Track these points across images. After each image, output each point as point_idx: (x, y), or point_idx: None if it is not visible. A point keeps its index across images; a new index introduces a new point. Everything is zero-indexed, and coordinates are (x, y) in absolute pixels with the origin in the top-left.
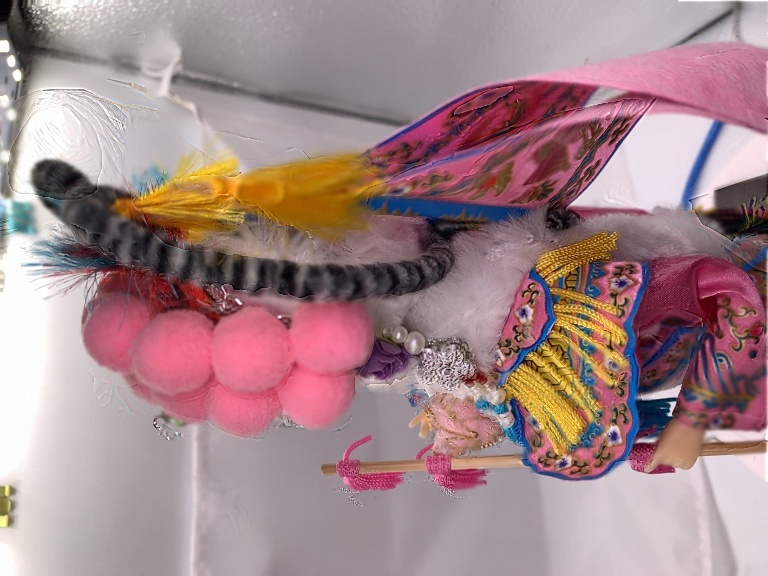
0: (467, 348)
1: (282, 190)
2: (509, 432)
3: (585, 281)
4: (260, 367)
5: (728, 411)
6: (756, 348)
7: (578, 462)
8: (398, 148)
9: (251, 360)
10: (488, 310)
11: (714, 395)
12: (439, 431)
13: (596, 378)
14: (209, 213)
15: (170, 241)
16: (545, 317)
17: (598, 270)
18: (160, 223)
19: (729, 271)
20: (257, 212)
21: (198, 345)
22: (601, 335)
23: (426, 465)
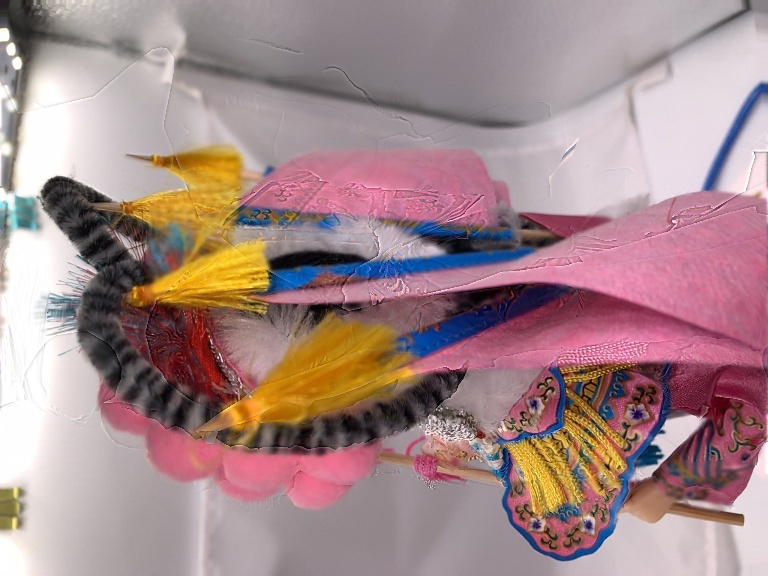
0: (472, 419)
1: (307, 410)
2: (495, 473)
3: (603, 397)
4: (268, 482)
5: (704, 486)
6: (750, 453)
7: (550, 531)
8: (439, 298)
9: (260, 477)
10: (500, 393)
11: (696, 477)
12: (432, 443)
13: (587, 477)
14: (231, 303)
15: (189, 325)
16: (554, 419)
17: (619, 387)
18: (179, 307)
19: (752, 378)
20: (281, 308)
21: (211, 449)
22: (602, 454)
23: (414, 464)
